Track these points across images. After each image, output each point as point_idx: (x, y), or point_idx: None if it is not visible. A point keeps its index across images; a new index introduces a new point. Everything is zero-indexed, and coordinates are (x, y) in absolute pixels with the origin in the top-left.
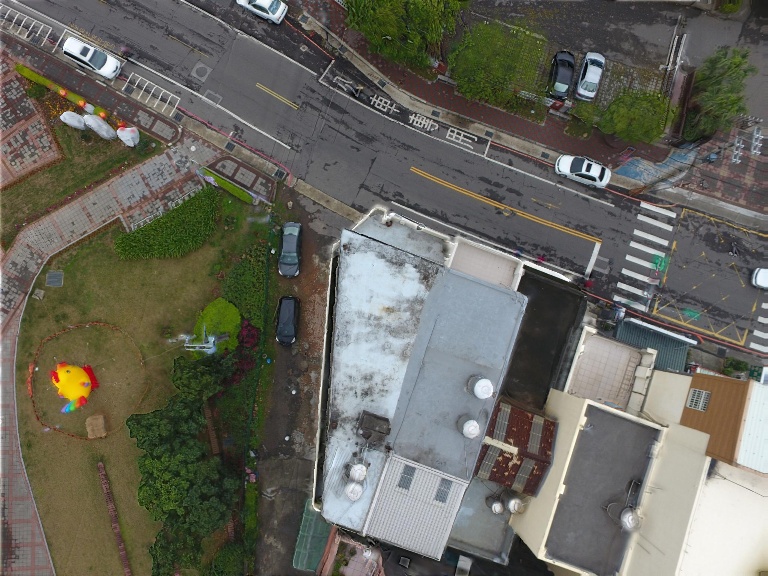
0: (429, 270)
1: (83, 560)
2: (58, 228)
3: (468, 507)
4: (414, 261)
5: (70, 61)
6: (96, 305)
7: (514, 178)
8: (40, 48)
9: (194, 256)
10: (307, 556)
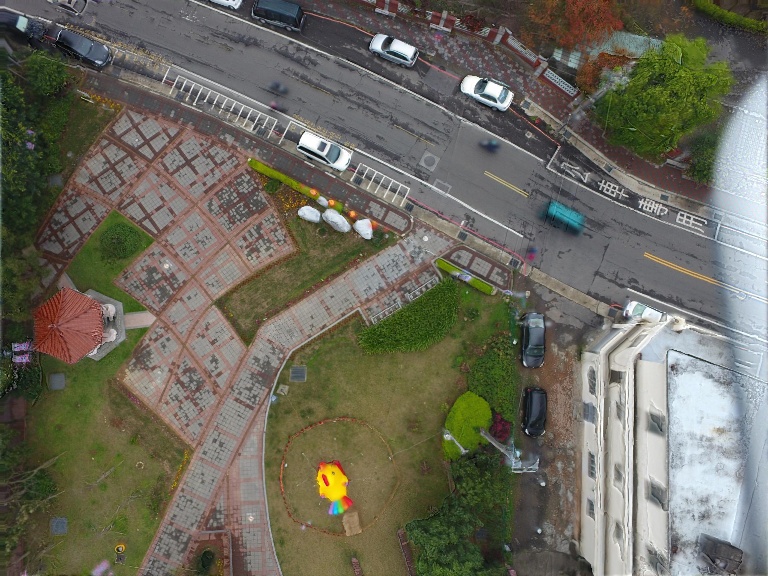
0: (756, 389)
1: None
2: (297, 322)
3: None
4: (741, 380)
5: (297, 153)
6: (343, 400)
7: (746, 261)
8: (267, 140)
9: (436, 348)
10: None
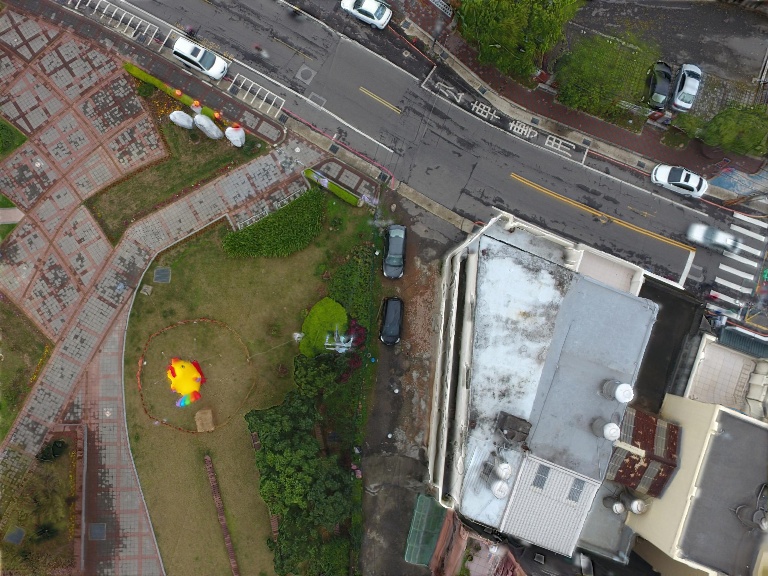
0: (564, 277)
1: (189, 550)
2: (165, 225)
3: None
4: (550, 267)
5: (176, 61)
6: (204, 302)
7: (611, 186)
8: (147, 47)
9: (300, 256)
10: (419, 551)
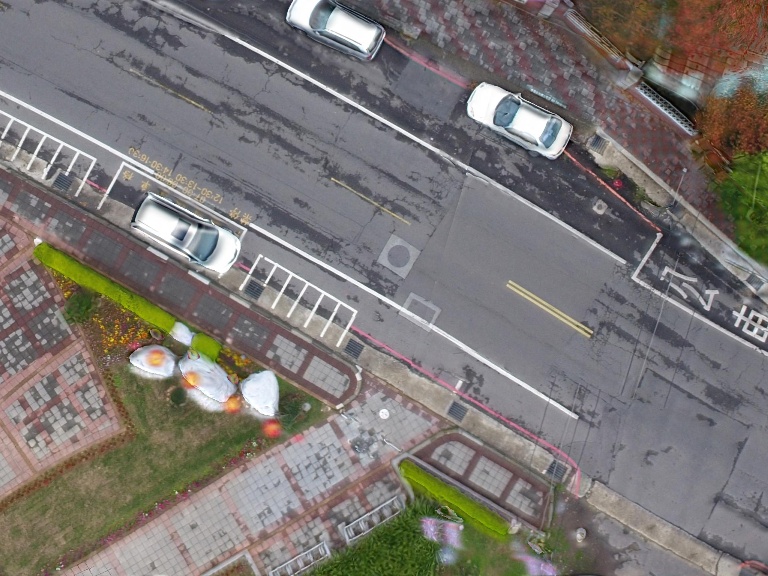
0: None
1: None
2: (124, 574)
3: None
4: None
5: (134, 229)
6: None
7: None
8: (74, 201)
9: None
10: None
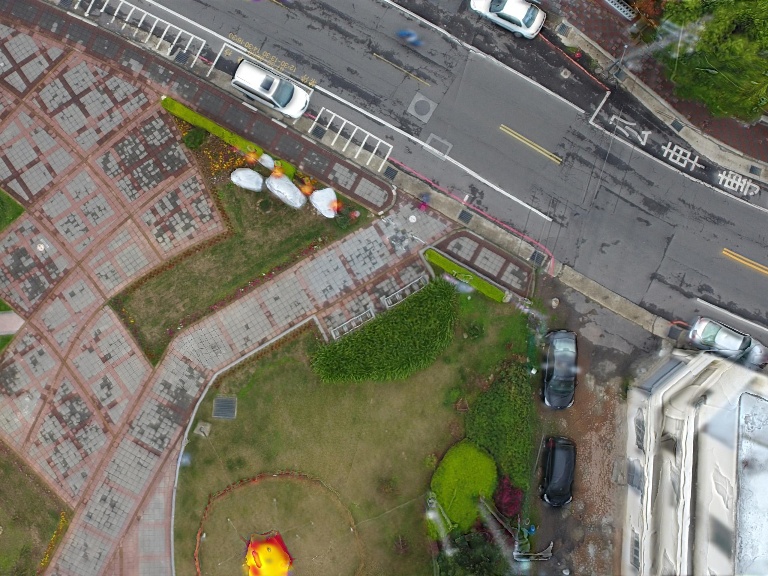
0: None
1: None
2: (227, 333)
3: None
4: None
5: (233, 90)
6: (288, 446)
7: None
8: (190, 70)
9: (422, 376)
10: None
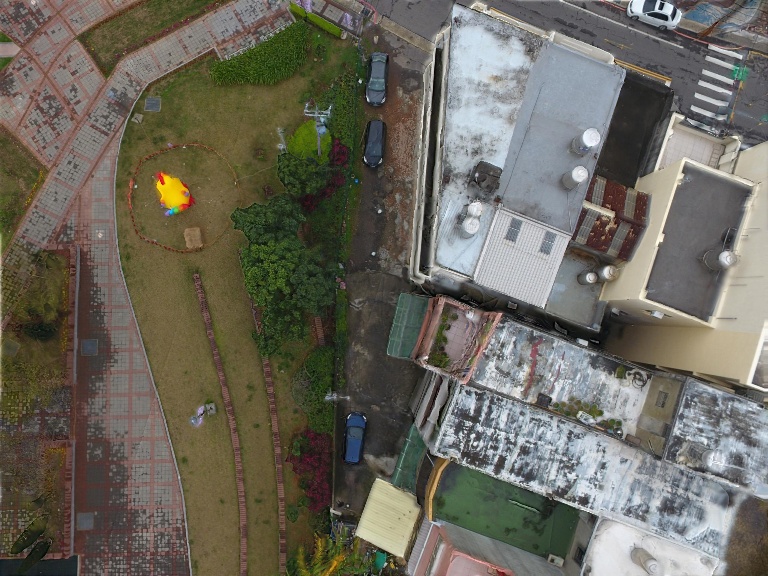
0: (534, 43)
1: (179, 365)
2: (156, 58)
3: (561, 283)
4: (520, 34)
5: None
6: (193, 127)
7: (588, 20)
8: None
9: (285, 84)
10: (401, 345)
